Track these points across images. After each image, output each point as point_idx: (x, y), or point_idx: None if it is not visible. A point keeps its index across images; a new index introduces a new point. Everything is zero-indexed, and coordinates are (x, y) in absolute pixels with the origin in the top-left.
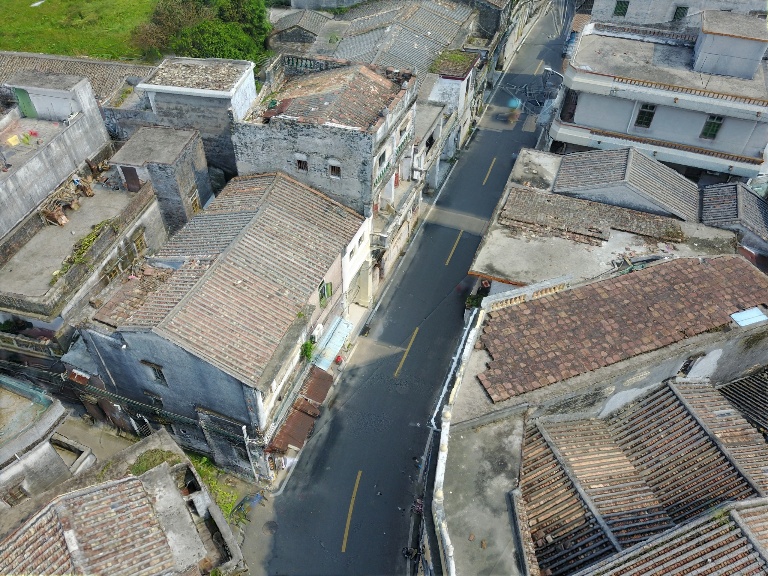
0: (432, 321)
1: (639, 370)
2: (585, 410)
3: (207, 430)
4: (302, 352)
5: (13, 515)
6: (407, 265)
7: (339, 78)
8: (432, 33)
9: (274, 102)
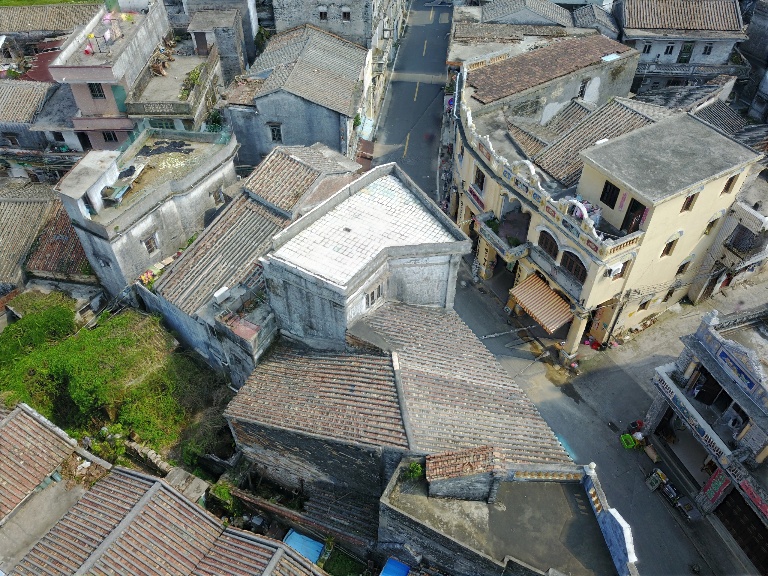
0: (417, 129)
1: (558, 85)
2: (532, 116)
3: None
4: (355, 122)
5: (234, 187)
6: (388, 104)
7: None
8: None
9: None
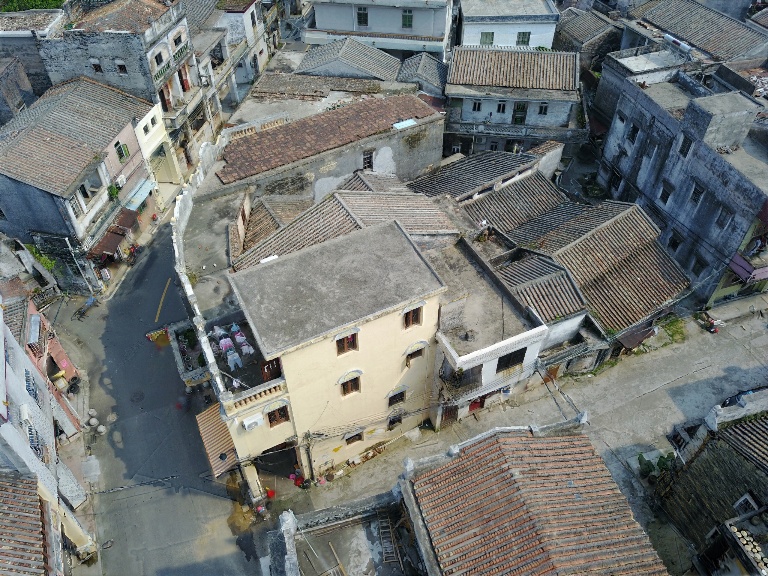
0: None
1: (326, 159)
2: (299, 193)
3: (45, 254)
4: (109, 193)
5: None
6: None
7: (120, 4)
8: None
9: (70, 25)
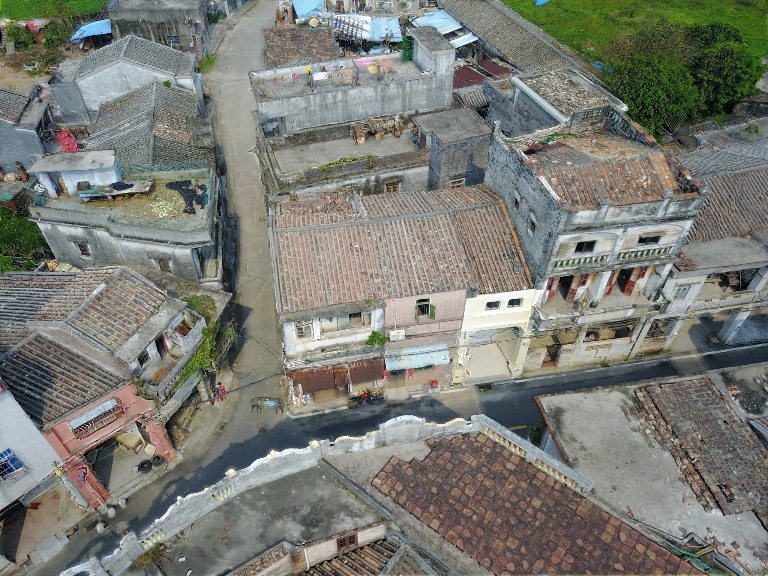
0: None
1: None
2: None
3: None
4: (371, 337)
5: (137, 268)
6: (594, 376)
7: (622, 151)
8: None
9: (549, 140)
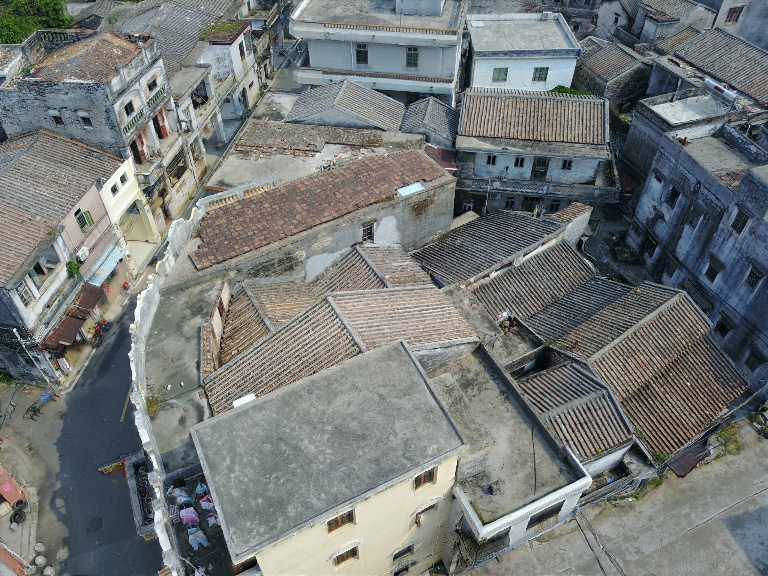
0: None
1: (319, 235)
2: (288, 274)
3: None
4: (68, 269)
5: None
6: None
7: (85, 45)
8: (205, 7)
9: (28, 71)
